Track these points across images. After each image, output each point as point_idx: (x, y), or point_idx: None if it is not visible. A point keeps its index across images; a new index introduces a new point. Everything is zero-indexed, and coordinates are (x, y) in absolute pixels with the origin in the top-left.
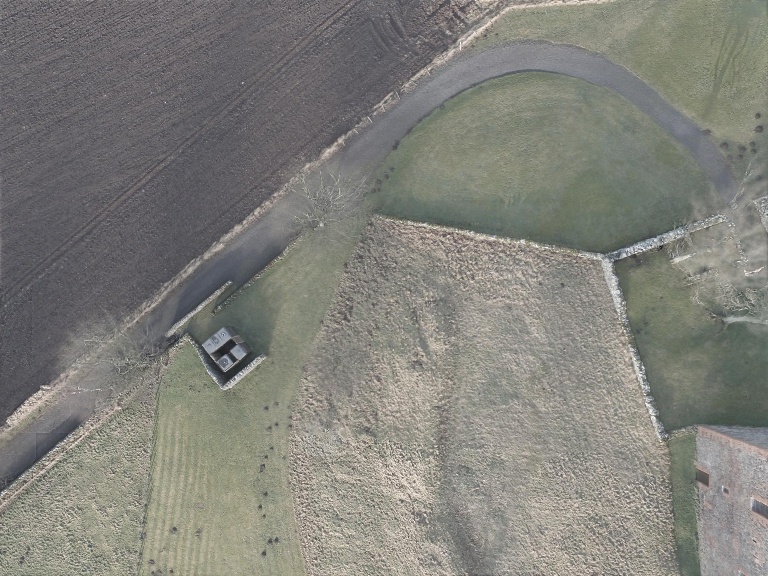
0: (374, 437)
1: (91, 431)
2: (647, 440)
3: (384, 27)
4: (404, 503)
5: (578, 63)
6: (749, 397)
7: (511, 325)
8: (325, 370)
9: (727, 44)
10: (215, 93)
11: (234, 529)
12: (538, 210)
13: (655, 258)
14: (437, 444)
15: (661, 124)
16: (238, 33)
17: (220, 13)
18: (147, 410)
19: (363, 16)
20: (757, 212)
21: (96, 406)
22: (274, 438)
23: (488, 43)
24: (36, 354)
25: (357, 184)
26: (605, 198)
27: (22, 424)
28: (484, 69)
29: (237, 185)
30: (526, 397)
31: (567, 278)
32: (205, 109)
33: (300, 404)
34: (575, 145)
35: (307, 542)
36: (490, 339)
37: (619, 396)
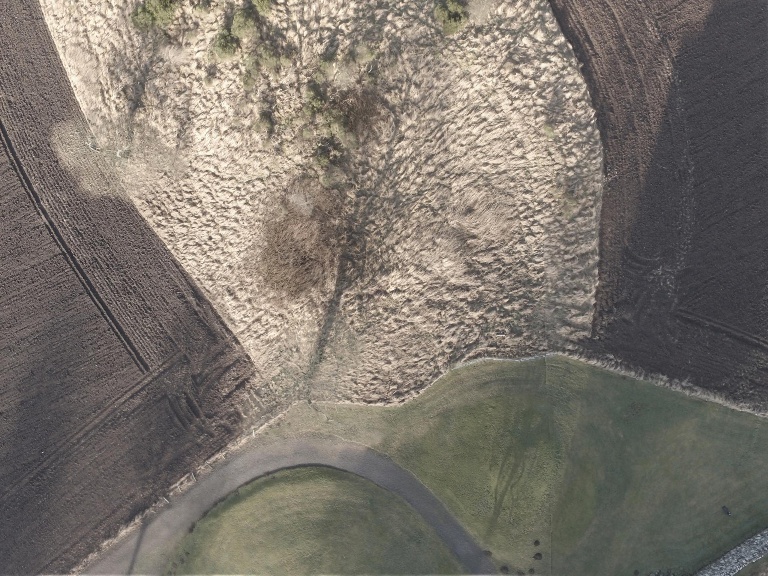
0: None
1: None
2: None
3: (180, 405)
4: None
5: (367, 463)
6: None
7: None
8: None
9: (504, 472)
10: (16, 461)
11: None
12: None
13: None
14: None
15: (445, 539)
16: (38, 401)
17: (20, 380)
18: None
19: (160, 393)
20: None
21: None
22: None
23: (281, 432)
24: None
25: None
26: None
27: None
28: (277, 458)
29: (38, 556)
30: None
31: None
32: (6, 476)
33: None
34: (358, 559)
35: None
36: None
37: None
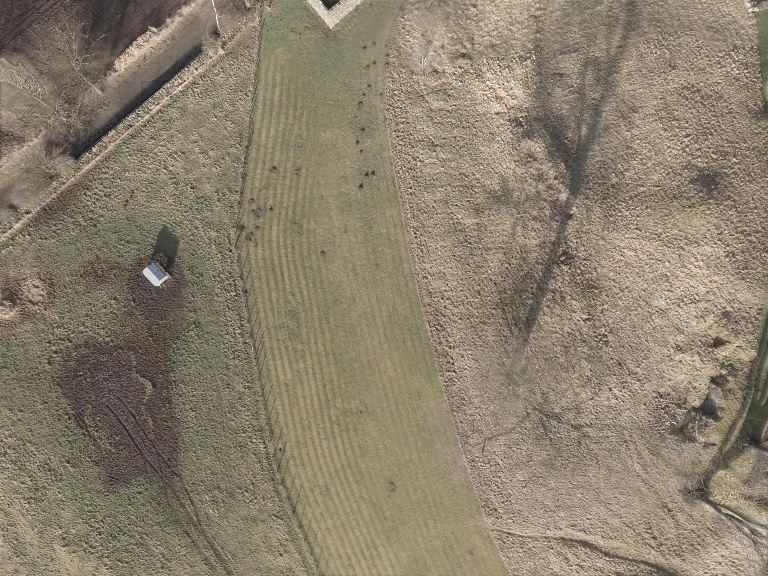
0: (470, 60)
1: (195, 76)
2: (736, 14)
3: None
4: (500, 114)
5: None
6: None
7: None
8: (421, 8)
9: None
10: None
11: (332, 165)
12: None
13: None
14: (534, 50)
15: None
16: None
17: None
18: (249, 54)
19: None
20: None
21: (202, 43)
22: (371, 76)
23: None
24: (142, 2)
25: None
26: None
27: (127, 71)
28: None
29: None
30: None
31: None
32: None
33: (397, 42)
34: None
35: (402, 173)
36: None
37: None
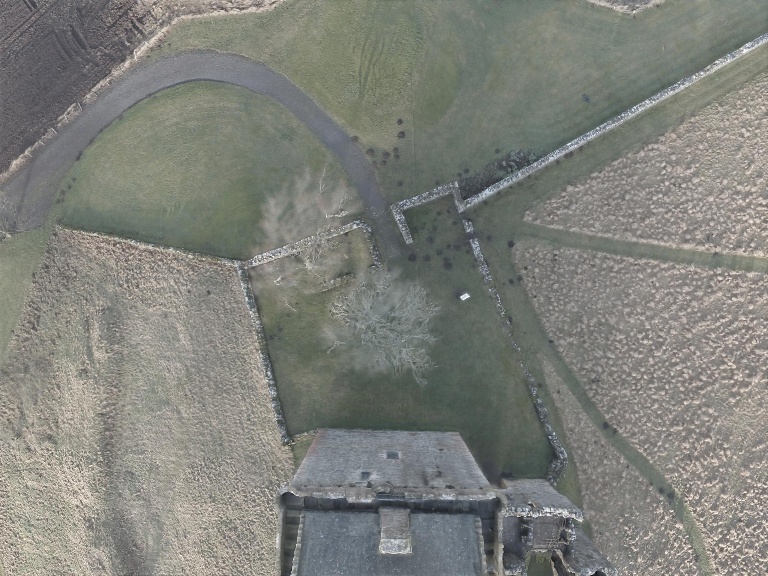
0: (55, 444)
1: None
2: (274, 444)
3: (67, 39)
4: (78, 509)
5: (242, 72)
6: (372, 400)
7: (166, 332)
8: (16, 379)
9: (366, 51)
10: None
11: None
12: (194, 218)
13: (291, 264)
14: (101, 451)
15: (314, 131)
16: None
17: None
18: None
19: (47, 28)
20: (394, 217)
21: None
22: None
23: (162, 53)
24: None
25: (0, 197)
26: (252, 206)
27: None
28: (158, 79)
29: None
30: (174, 403)
31: (213, 285)
32: None
33: None
34: (231, 153)
35: (4, 548)
36: (151, 346)
37: (252, 401)
